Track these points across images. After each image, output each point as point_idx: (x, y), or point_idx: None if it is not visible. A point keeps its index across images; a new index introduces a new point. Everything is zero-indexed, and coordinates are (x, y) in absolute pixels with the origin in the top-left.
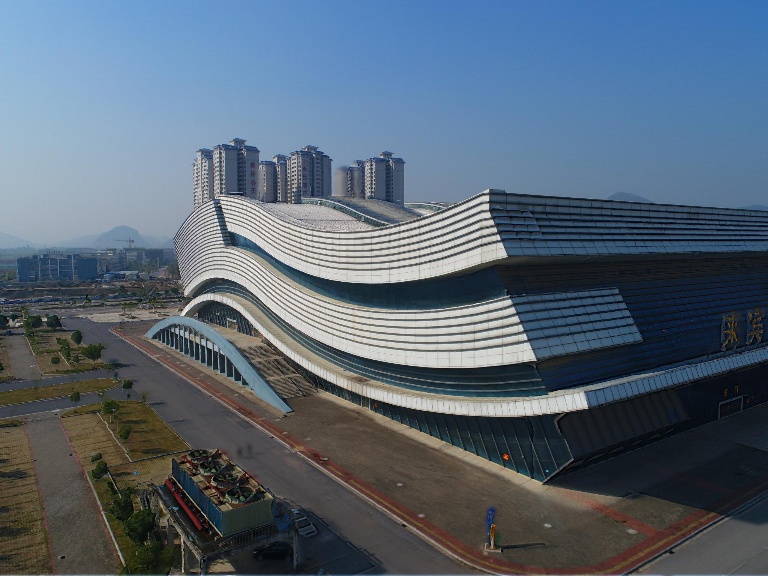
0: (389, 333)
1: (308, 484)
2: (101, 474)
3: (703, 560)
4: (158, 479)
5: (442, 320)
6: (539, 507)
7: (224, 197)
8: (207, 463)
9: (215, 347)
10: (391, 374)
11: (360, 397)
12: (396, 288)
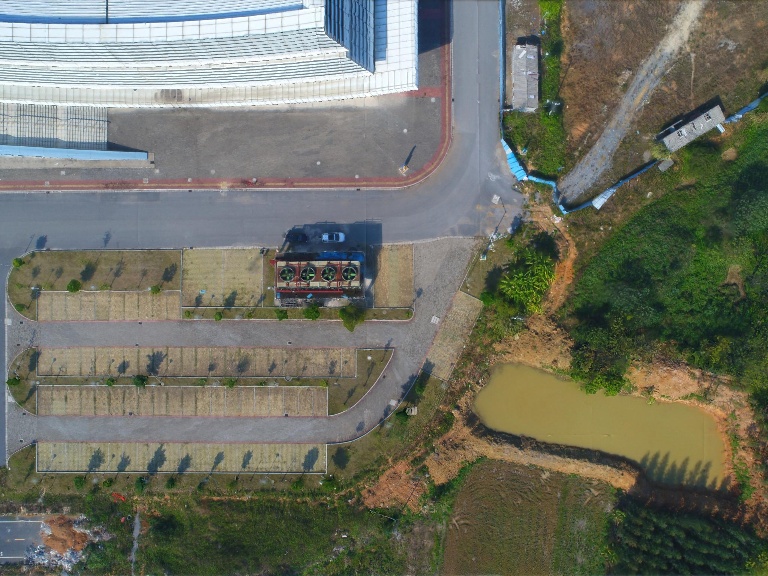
0: None
1: (283, 208)
2: (221, 316)
3: (466, 95)
4: (221, 283)
5: None
6: (390, 119)
7: None
8: (303, 276)
9: None
10: None
11: None
12: None
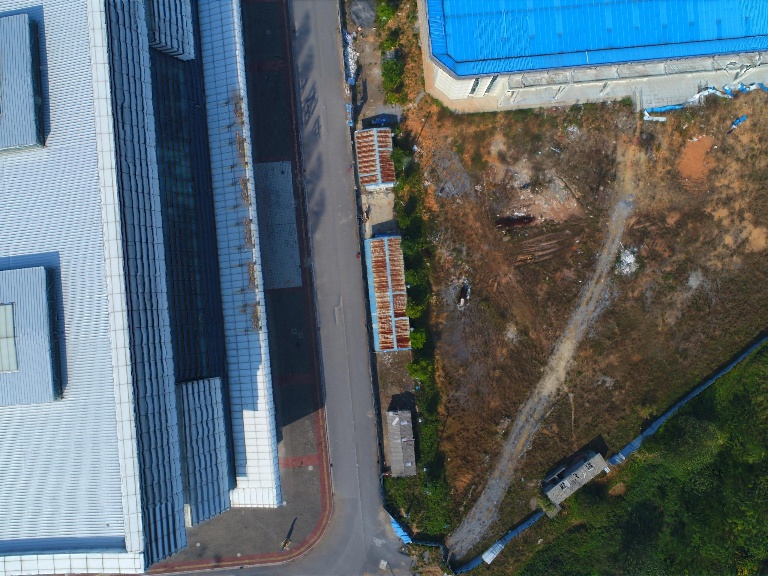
0: None
1: None
2: None
3: (344, 459)
4: None
5: None
6: None
7: None
8: None
9: None
10: None
11: None
12: None
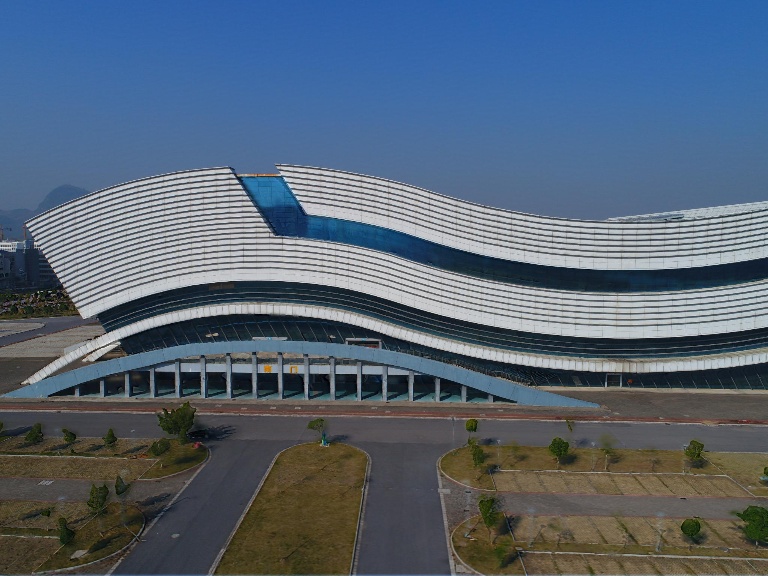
0: (676, 311)
1: None
2: None
3: None
4: None
5: (749, 293)
6: None
7: (297, 167)
8: None
9: (369, 369)
10: (657, 348)
11: (605, 379)
12: (683, 272)
